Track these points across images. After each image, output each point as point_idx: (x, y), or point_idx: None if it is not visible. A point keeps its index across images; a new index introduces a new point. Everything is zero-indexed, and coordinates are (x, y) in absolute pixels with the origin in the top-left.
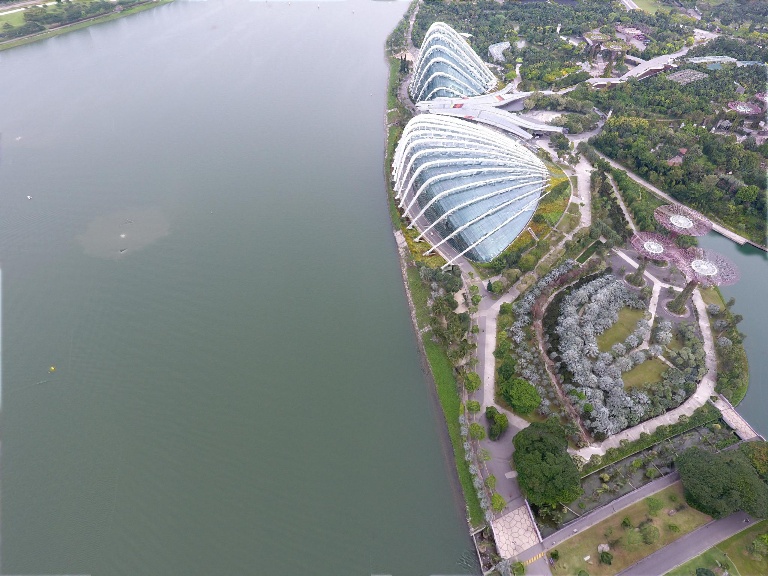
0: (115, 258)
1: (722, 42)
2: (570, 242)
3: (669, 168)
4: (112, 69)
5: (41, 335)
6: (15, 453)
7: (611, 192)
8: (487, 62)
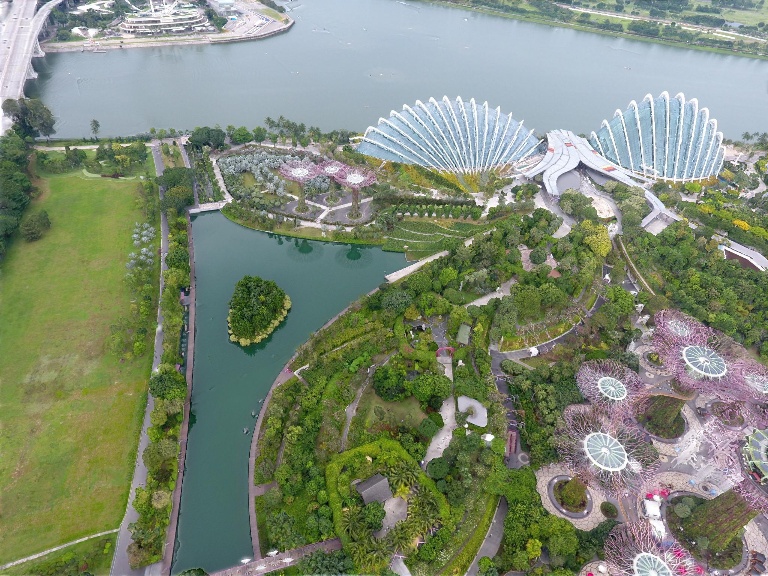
0: (364, 75)
1: None
2: None
3: None
4: (576, 55)
5: None
6: None
7: None
8: None
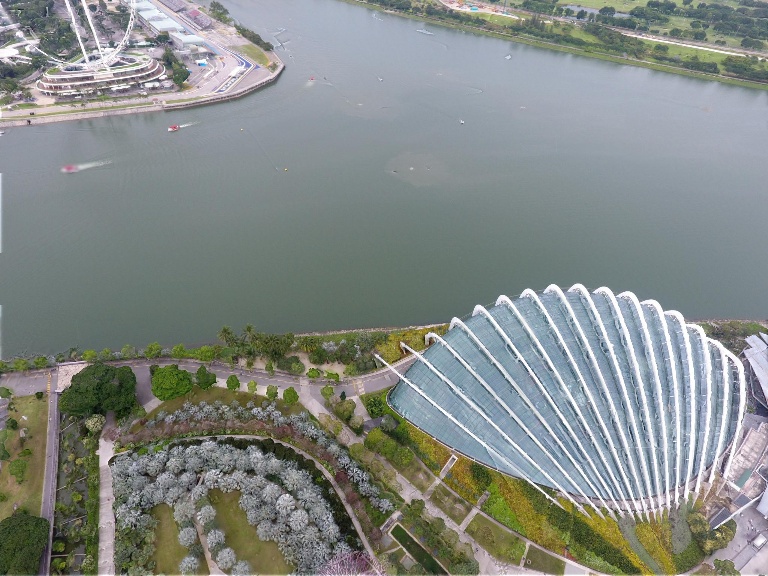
0: (386, 170)
1: None
2: (417, 503)
3: None
4: (675, 117)
5: (314, 161)
6: (231, 172)
7: None
8: None
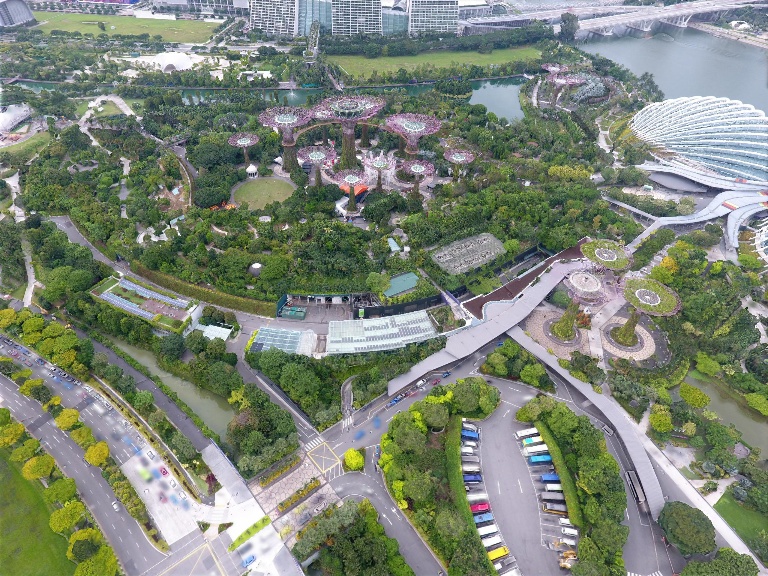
0: None
1: None
2: None
3: None
4: None
5: None
6: None
7: None
8: None
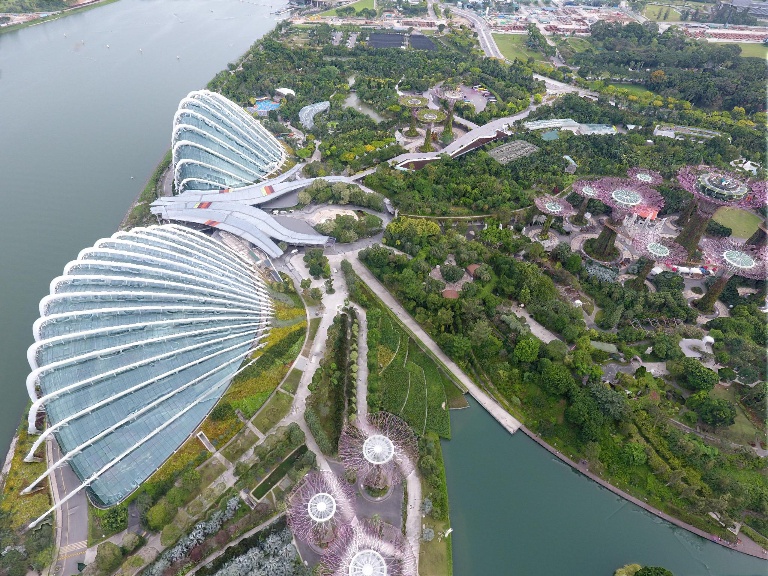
0: None
1: (567, 102)
2: (239, 467)
3: (441, 304)
4: None
5: None
6: None
7: (352, 349)
8: (296, 128)
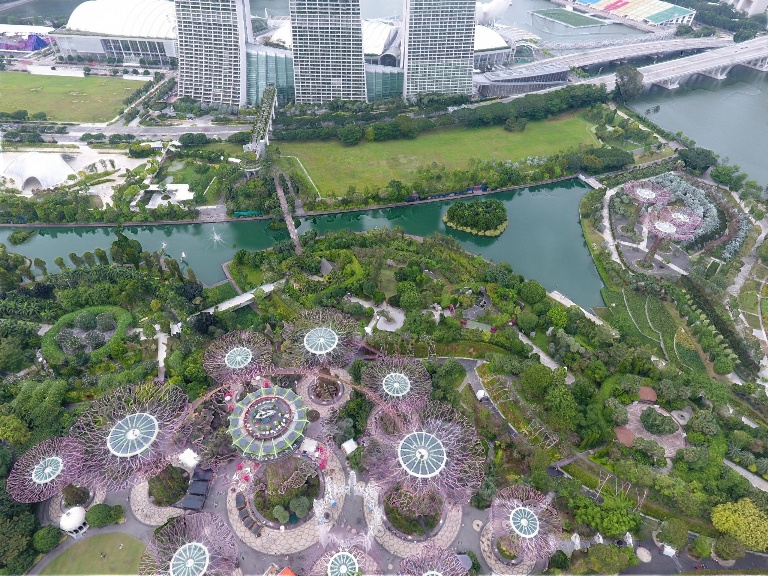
0: None
1: None
2: None
3: None
4: None
5: None
6: None
7: None
8: None
